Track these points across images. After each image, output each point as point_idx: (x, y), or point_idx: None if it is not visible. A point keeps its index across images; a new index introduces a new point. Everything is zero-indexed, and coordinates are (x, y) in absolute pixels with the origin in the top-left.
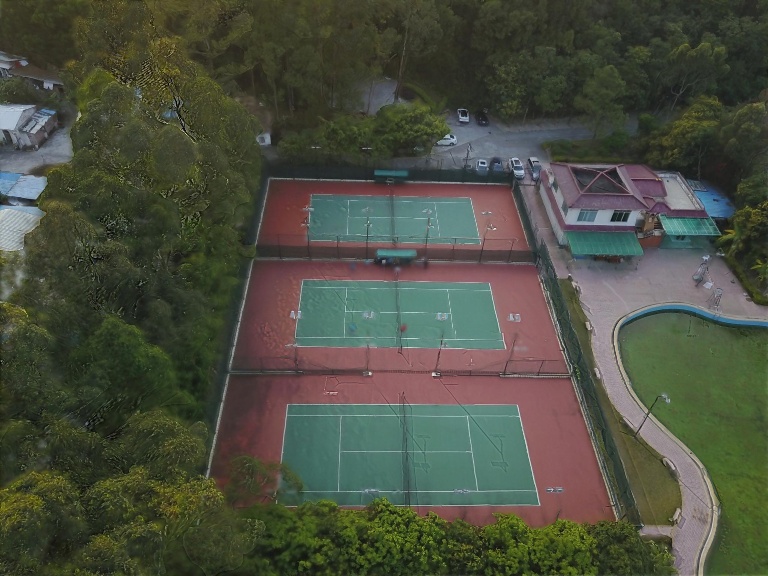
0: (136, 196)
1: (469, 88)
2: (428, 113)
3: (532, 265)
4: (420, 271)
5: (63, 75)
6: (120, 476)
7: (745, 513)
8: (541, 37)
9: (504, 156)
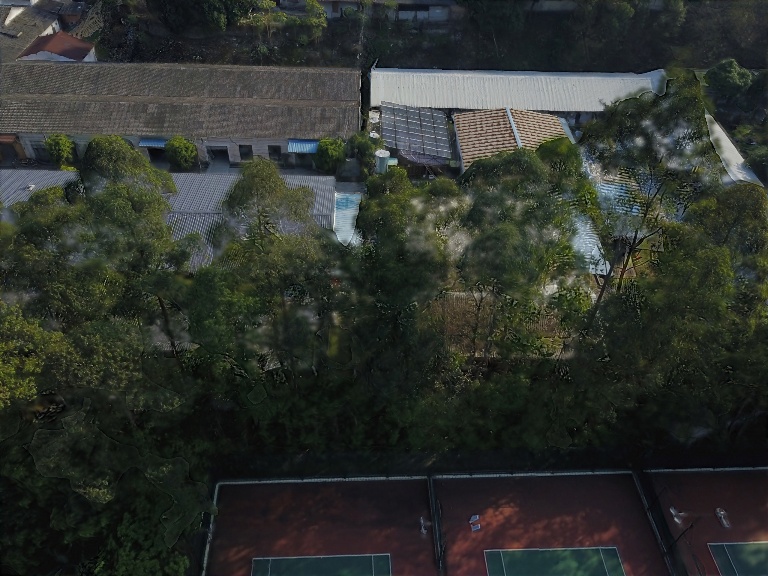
0: (408, 245)
1: None
2: None
3: None
4: None
5: None
6: (27, 318)
7: None
8: None
9: None
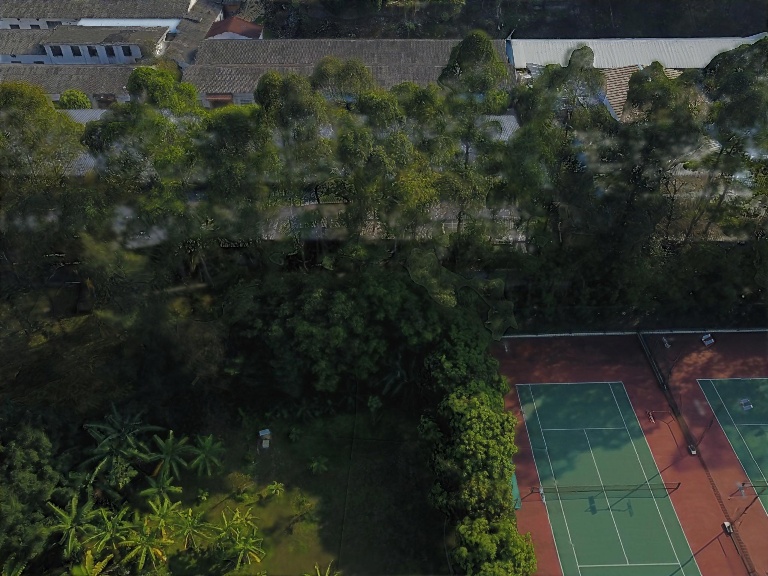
0: (675, 114)
1: None
2: None
3: None
4: None
5: None
6: (424, 160)
7: None
8: None
9: None
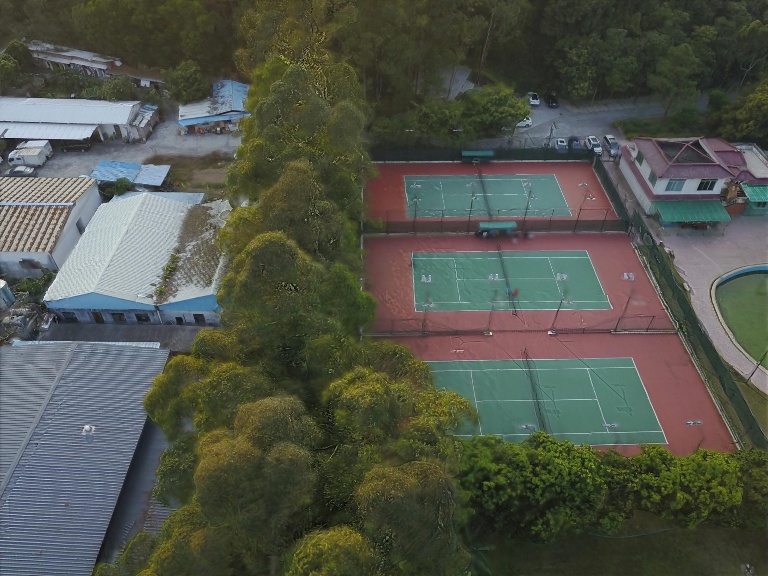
0: (321, 165)
1: (537, 72)
2: (511, 95)
3: (624, 234)
4: (519, 242)
5: (164, 72)
6: (389, 385)
7: None
8: (609, 20)
9: (579, 135)
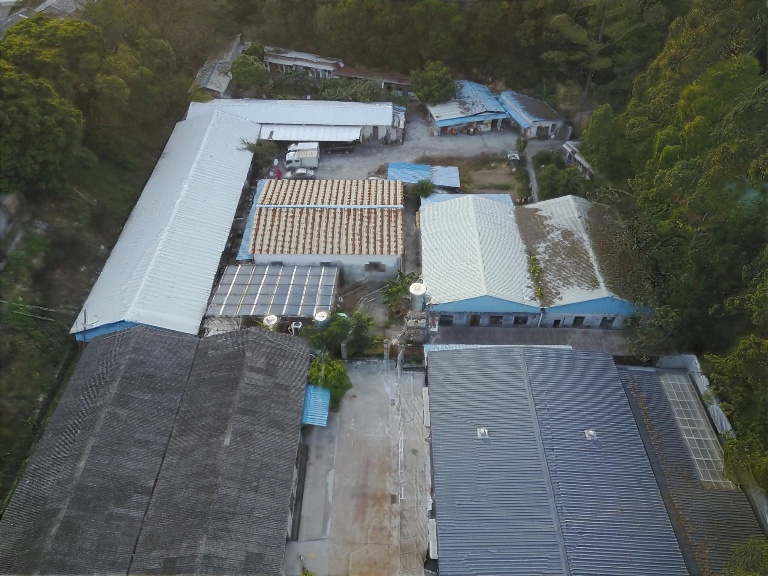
0: None
1: None
2: None
3: None
4: None
5: (414, 73)
6: None
7: None
8: None
9: None
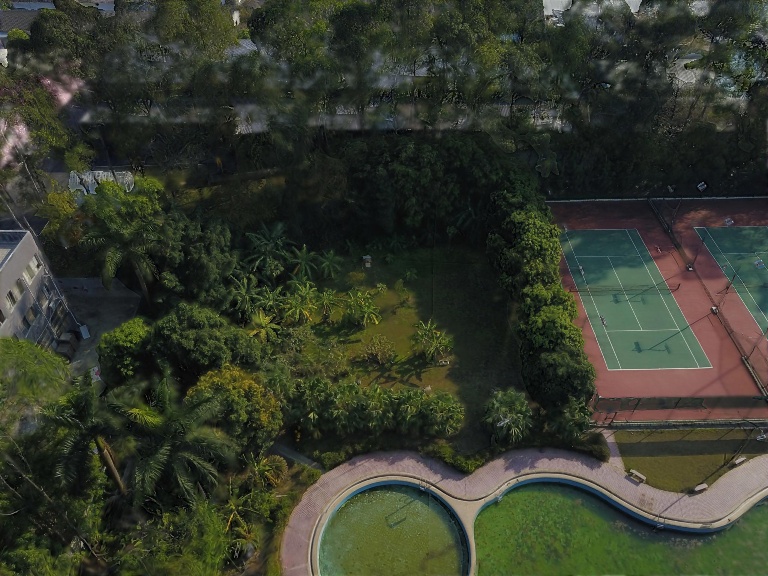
0: (678, 9)
1: None
2: None
3: None
4: None
5: None
6: (496, 37)
7: (674, 567)
8: None
9: None
